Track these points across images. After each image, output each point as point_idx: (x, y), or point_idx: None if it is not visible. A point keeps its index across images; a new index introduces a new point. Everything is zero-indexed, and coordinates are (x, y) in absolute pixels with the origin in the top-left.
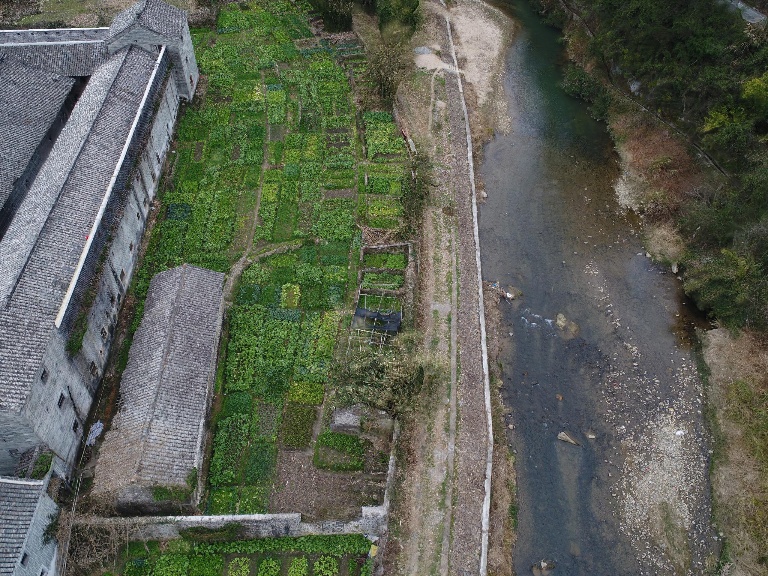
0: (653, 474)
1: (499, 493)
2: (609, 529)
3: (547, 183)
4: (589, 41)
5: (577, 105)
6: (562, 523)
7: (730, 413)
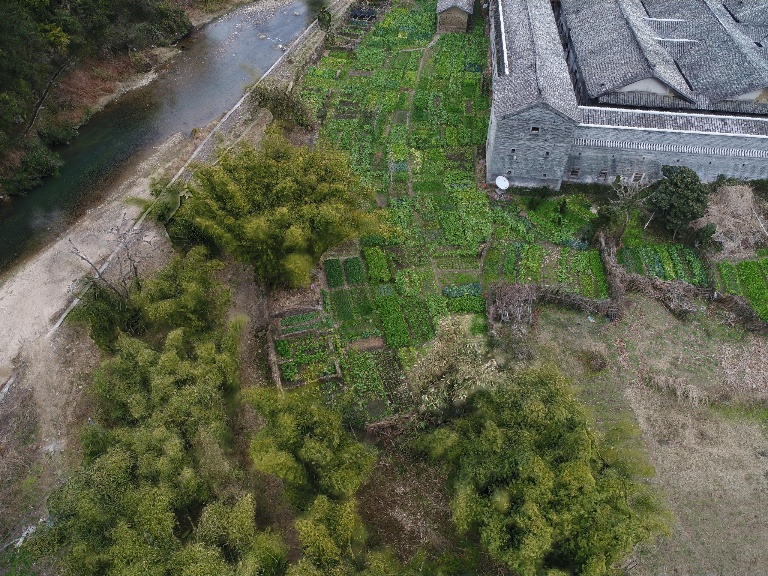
0: (272, 4)
1: (334, 1)
2: (300, 0)
3: (192, 94)
4: (2, 135)
5: (67, 158)
6: (315, 3)
7: (224, 7)
